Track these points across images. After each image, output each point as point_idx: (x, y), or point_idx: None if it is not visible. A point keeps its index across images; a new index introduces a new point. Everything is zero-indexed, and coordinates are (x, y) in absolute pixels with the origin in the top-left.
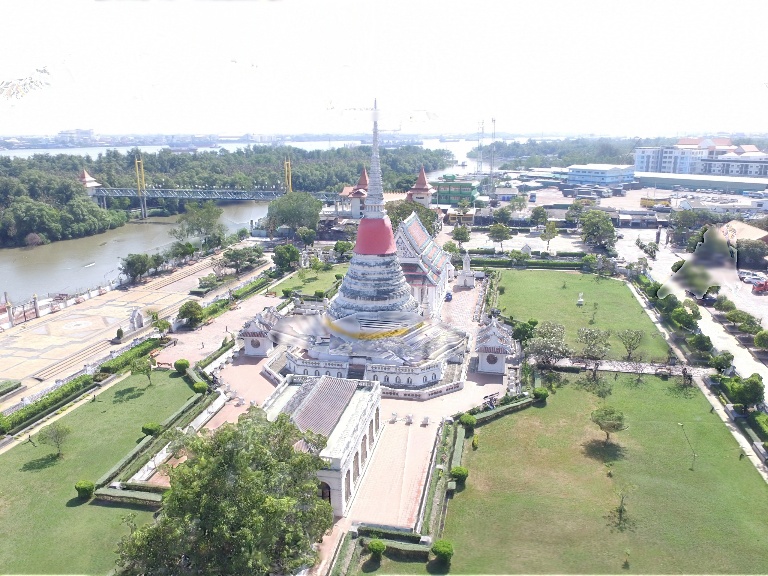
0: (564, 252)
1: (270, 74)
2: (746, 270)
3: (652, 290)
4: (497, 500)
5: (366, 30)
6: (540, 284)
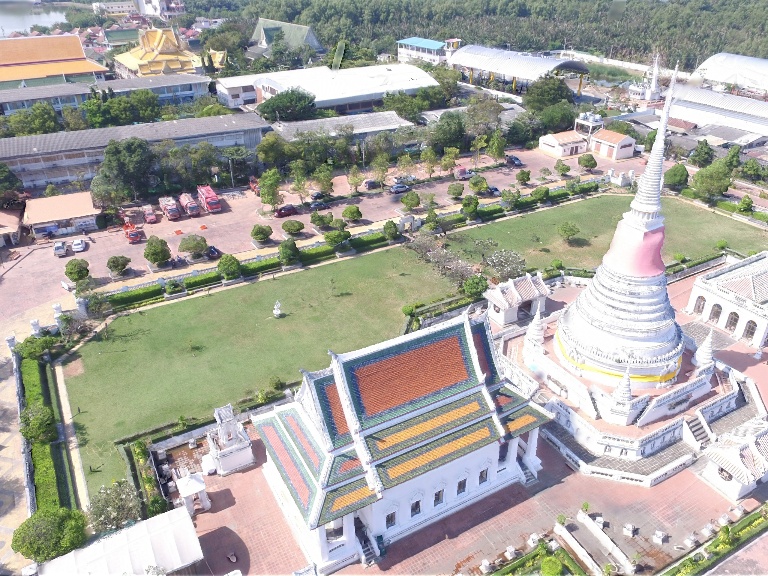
0: None
1: None
2: (17, 253)
3: (239, 264)
4: None
5: None
6: (188, 373)
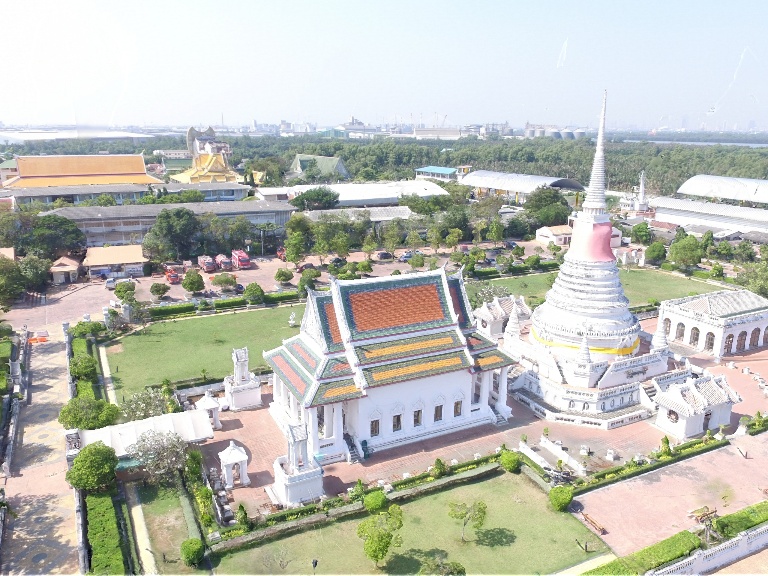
0: (9, 351)
1: (767, 83)
2: (74, 286)
3: None
4: (644, 300)
5: (765, 97)
6: (212, 354)
